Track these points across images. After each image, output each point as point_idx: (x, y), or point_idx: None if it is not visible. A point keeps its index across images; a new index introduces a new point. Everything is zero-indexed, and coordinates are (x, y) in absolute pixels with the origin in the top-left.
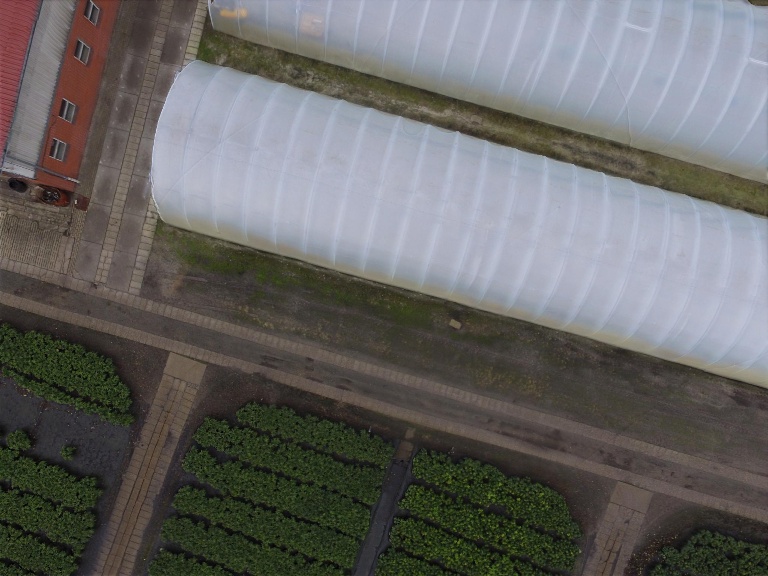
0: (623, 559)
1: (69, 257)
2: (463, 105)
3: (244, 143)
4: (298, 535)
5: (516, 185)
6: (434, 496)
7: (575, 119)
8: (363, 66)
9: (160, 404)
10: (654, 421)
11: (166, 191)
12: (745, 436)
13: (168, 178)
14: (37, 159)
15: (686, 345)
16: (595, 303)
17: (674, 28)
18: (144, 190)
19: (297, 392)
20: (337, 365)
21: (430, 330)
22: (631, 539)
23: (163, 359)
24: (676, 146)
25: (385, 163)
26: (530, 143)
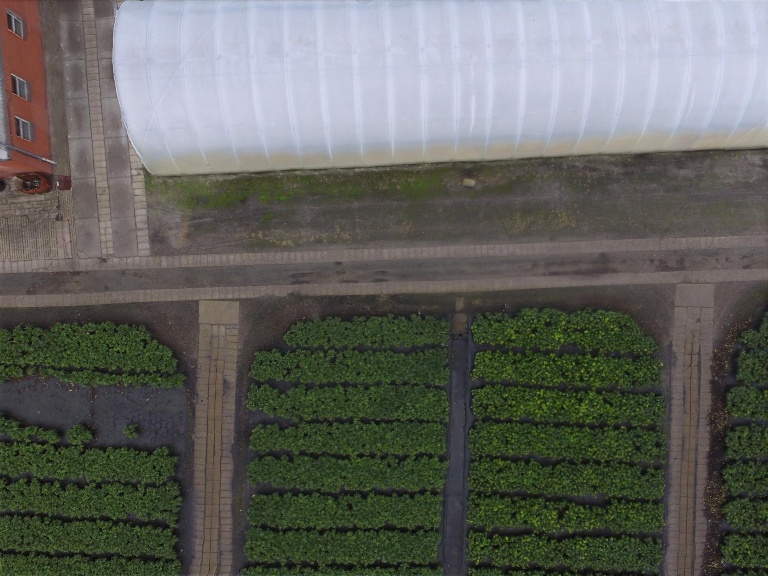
0: (706, 358)
1: (69, 240)
2: None
3: (204, 56)
4: (383, 437)
5: (485, 13)
6: (503, 356)
7: None
8: None
9: (206, 355)
10: (692, 214)
11: (143, 133)
12: None
13: (141, 117)
14: (5, 138)
15: (700, 122)
16: (599, 106)
17: None
18: (121, 150)
19: (336, 299)
20: (366, 260)
21: (446, 197)
22: (707, 336)
23: (194, 310)
24: None
25: (349, 32)
26: None
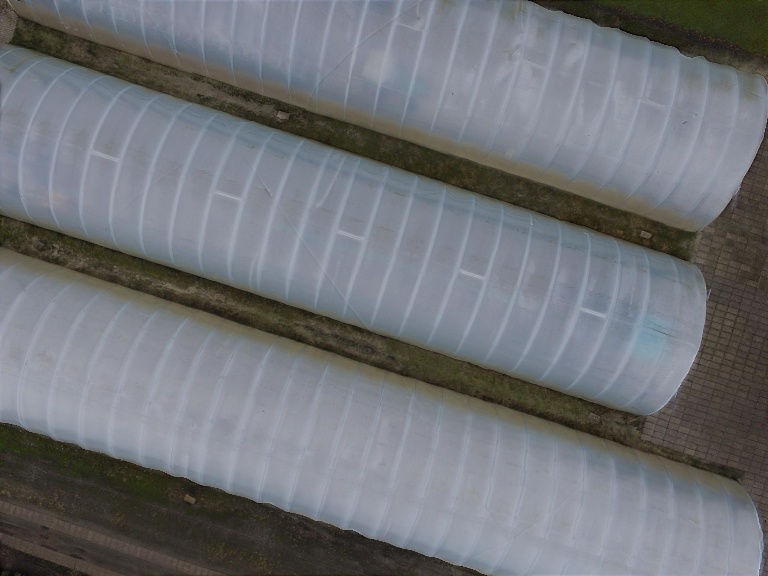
0: None
1: None
2: (207, 283)
3: None
4: None
5: (223, 387)
6: None
7: (309, 307)
8: (104, 244)
9: None
10: None
11: None
12: None
13: None
14: None
15: (397, 542)
16: (303, 502)
17: (386, 238)
18: None
19: (32, 559)
20: (71, 535)
21: (164, 504)
22: None
23: None
24: (408, 338)
25: (92, 362)
26: (272, 323)
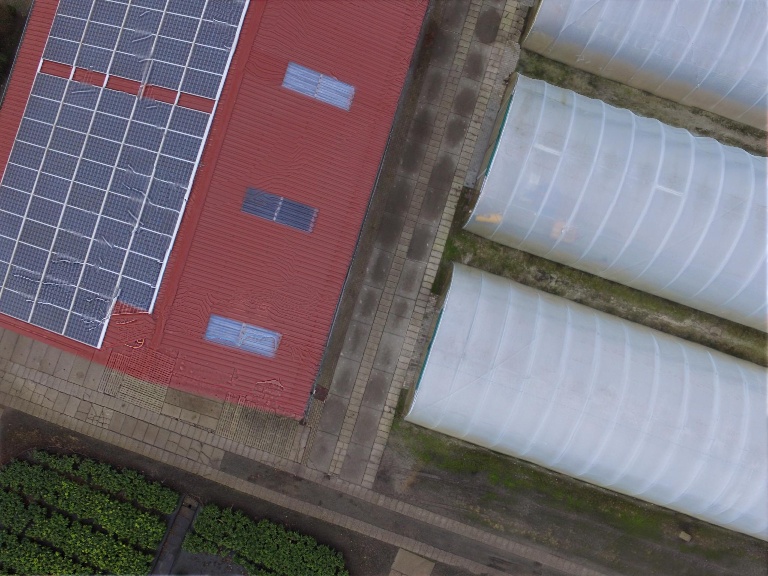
0: None
1: (304, 446)
2: (703, 316)
3: (516, 370)
4: None
5: None
6: None
7: None
8: (610, 275)
9: None
10: None
11: (426, 405)
12: None
13: (433, 396)
14: None
15: None
16: None
17: None
18: (383, 384)
19: None
20: (565, 571)
21: (660, 541)
22: None
23: (392, 555)
24: None
25: (653, 397)
26: None
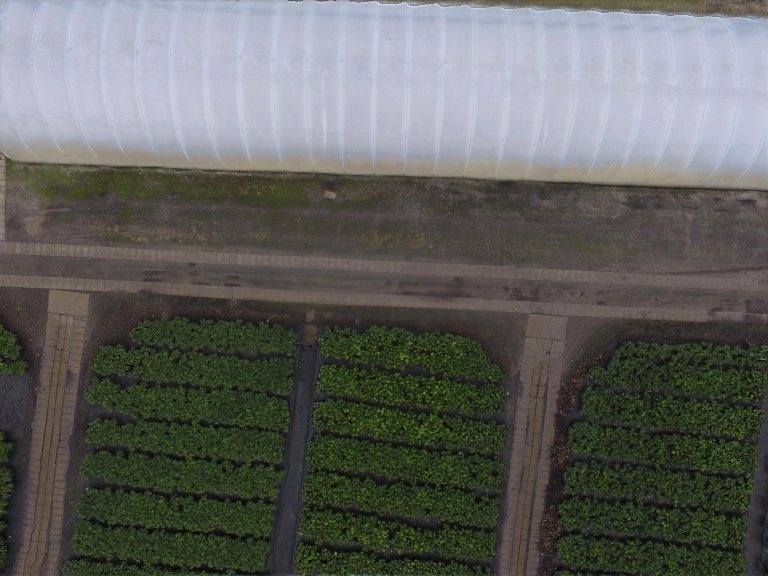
0: (553, 391)
1: None
2: None
3: (55, 47)
4: (220, 442)
5: (341, 27)
6: (347, 371)
7: None
8: None
9: (52, 344)
10: (551, 246)
11: None
12: (646, 240)
13: None
14: None
15: (556, 154)
16: (452, 130)
17: None
18: None
19: (186, 300)
20: (220, 263)
21: (305, 207)
22: (556, 369)
23: (44, 298)
24: None
25: (203, 35)
26: None
